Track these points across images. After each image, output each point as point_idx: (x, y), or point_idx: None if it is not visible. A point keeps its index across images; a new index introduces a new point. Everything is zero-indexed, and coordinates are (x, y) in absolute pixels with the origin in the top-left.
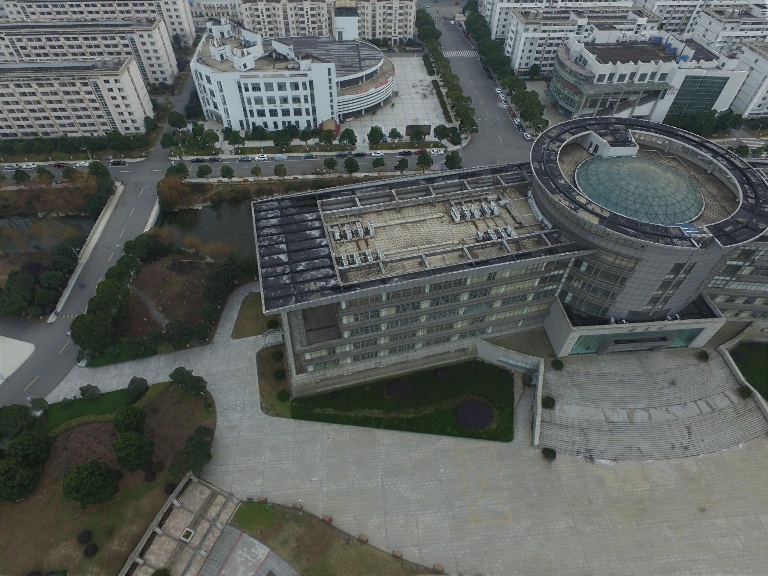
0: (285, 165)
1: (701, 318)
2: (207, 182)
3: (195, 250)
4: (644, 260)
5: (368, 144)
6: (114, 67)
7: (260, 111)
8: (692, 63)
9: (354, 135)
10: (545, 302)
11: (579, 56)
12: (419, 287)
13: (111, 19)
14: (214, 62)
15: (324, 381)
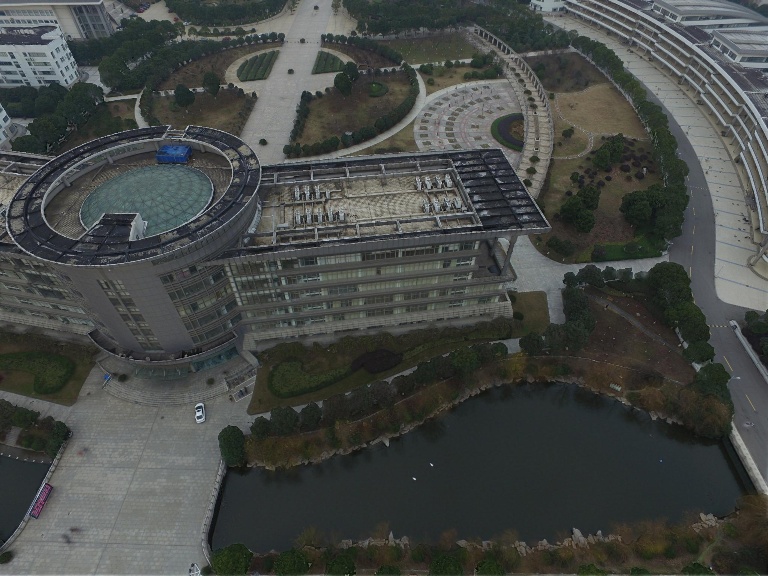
0: None
1: None
2: None
3: None
4: None
5: None
6: None
7: None
8: None
9: None
10: None
11: None
12: None
13: None
14: None
15: None
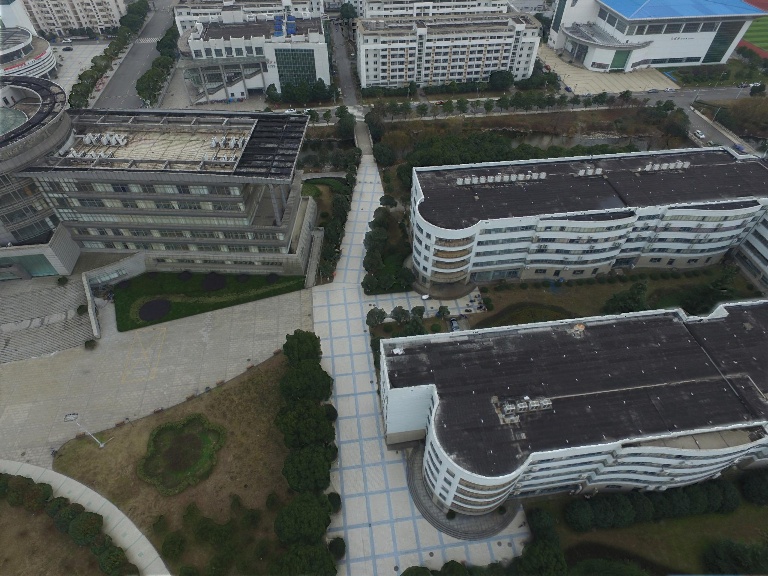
0: None
1: (27, 245)
2: None
3: None
4: None
5: None
6: None
7: None
8: (279, 37)
9: None
10: None
11: None
12: None
13: None
14: None
15: None
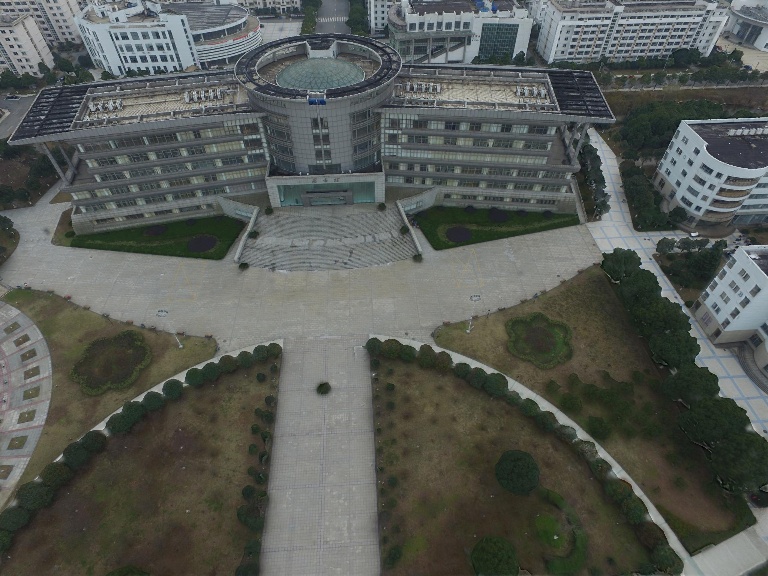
0: None
1: None
2: None
3: None
4: (290, 116)
5: None
6: (11, 21)
7: (132, 57)
8: (488, 13)
9: None
10: (260, 165)
11: None
12: (137, 138)
13: None
14: (96, 18)
15: (100, 224)
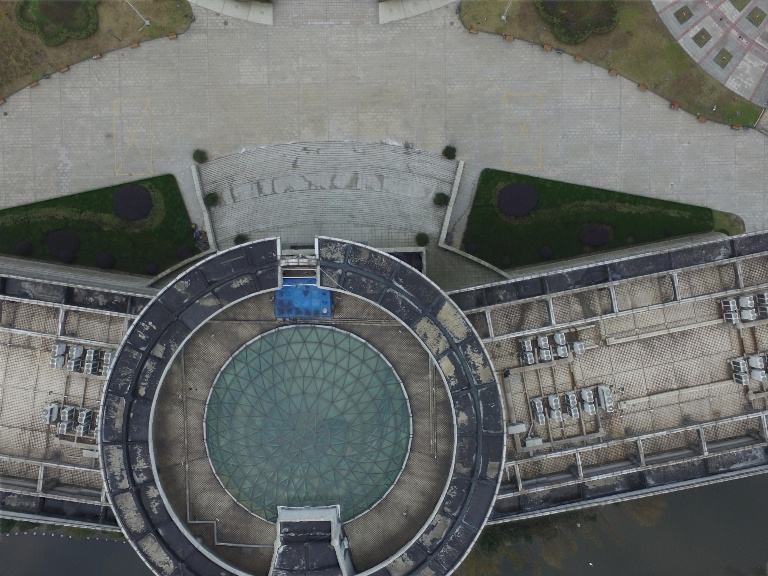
0: None
1: None
2: None
3: None
4: None
5: None
6: None
7: None
8: None
9: None
10: None
11: None
12: None
13: None
14: None
15: None
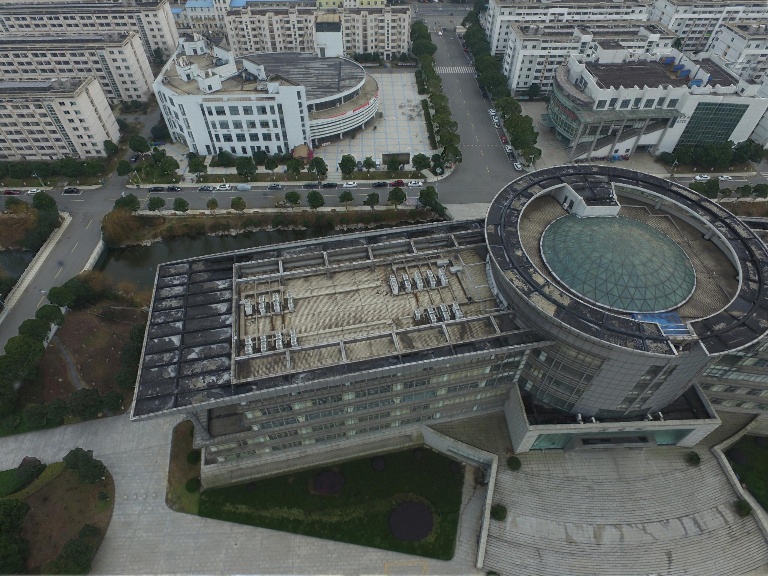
0: (247, 196)
1: (690, 419)
2: (160, 215)
3: (131, 296)
4: (612, 360)
5: (341, 173)
6: (71, 88)
7: (226, 135)
8: (706, 88)
9: (324, 164)
10: (501, 388)
11: (580, 77)
12: None
13: (84, 34)
14: (180, 82)
15: (241, 469)
